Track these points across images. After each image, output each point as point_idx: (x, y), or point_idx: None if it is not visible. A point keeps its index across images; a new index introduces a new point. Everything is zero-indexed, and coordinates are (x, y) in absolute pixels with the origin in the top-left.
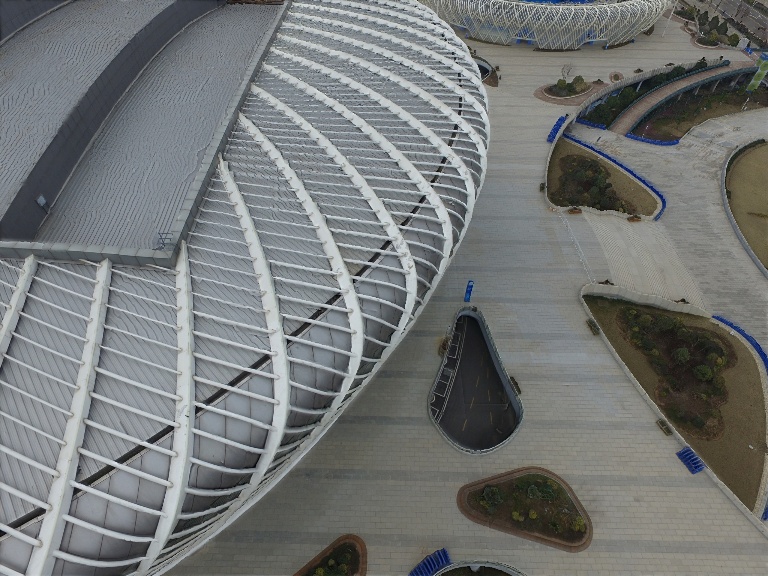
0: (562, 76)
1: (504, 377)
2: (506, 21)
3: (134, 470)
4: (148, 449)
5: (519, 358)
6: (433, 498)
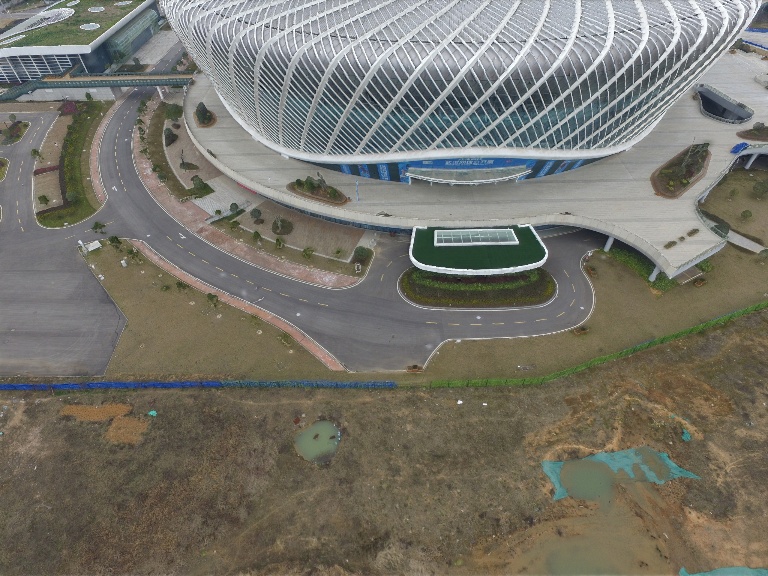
0: None
1: (733, 105)
2: None
3: (731, 4)
4: (729, 3)
5: (737, 100)
6: (725, 135)
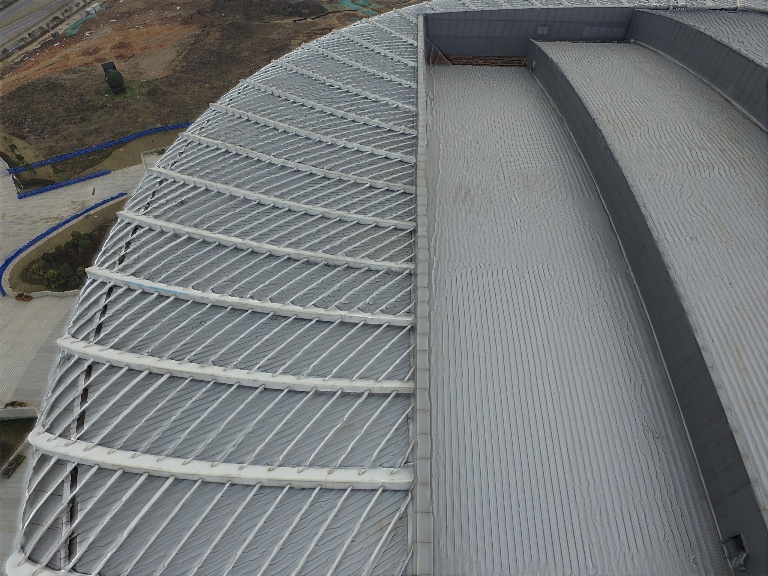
0: None
1: None
2: None
3: None
4: None
5: None
6: None
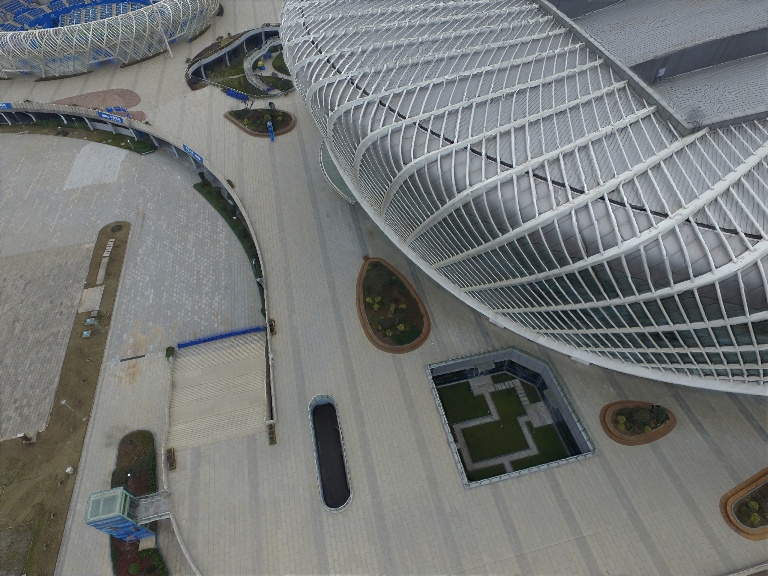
0: (275, 6)
1: None
2: (208, 1)
3: None
4: None
5: None
6: None
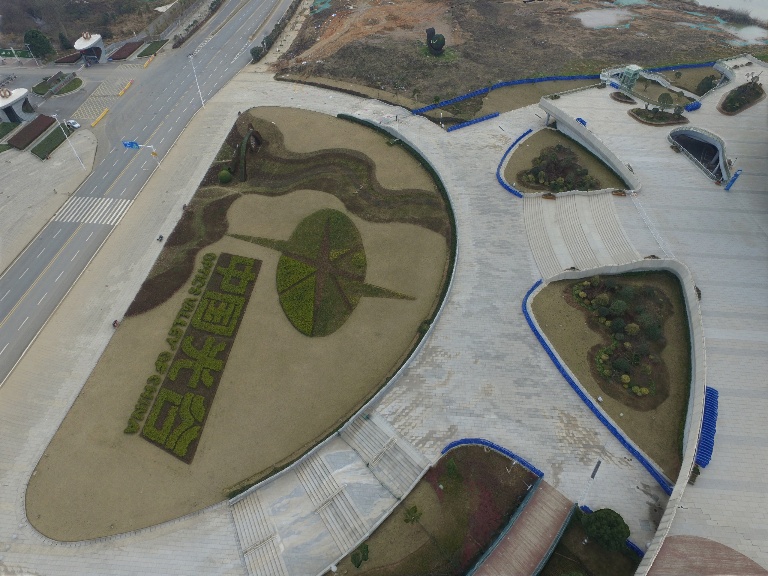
0: None
1: None
2: None
3: None
4: None
5: (676, 160)
6: None
